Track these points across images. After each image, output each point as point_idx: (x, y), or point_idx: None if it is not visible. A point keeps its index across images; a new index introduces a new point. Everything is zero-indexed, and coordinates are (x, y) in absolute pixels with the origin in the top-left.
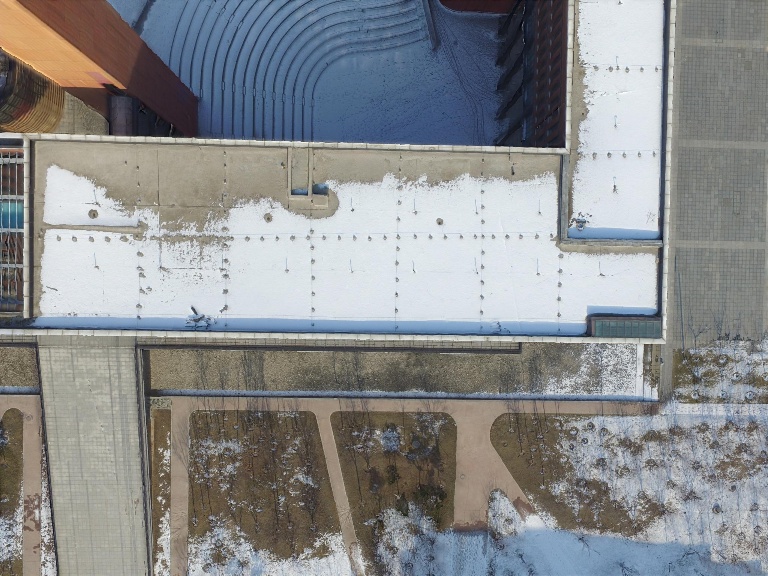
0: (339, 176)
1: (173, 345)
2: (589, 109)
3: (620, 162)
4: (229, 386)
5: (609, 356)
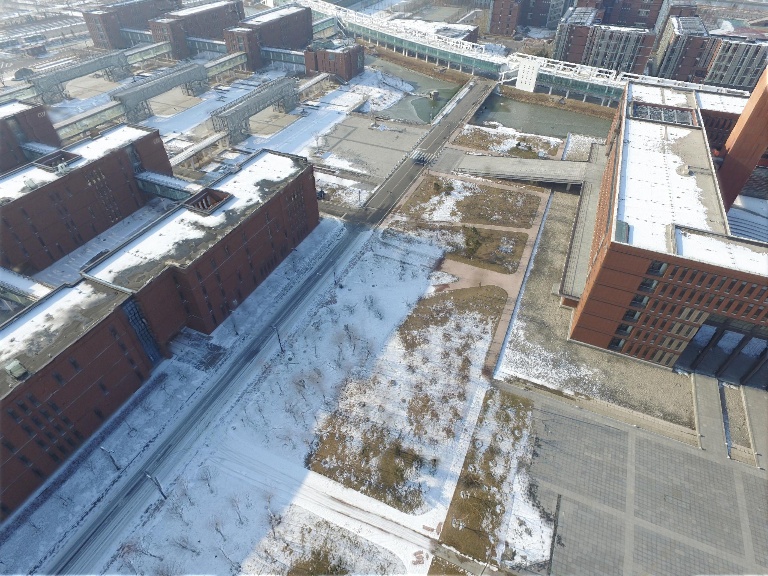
0: (699, 179)
1: (584, 189)
2: (759, 253)
3: (727, 255)
4: (551, 210)
5: (536, 361)
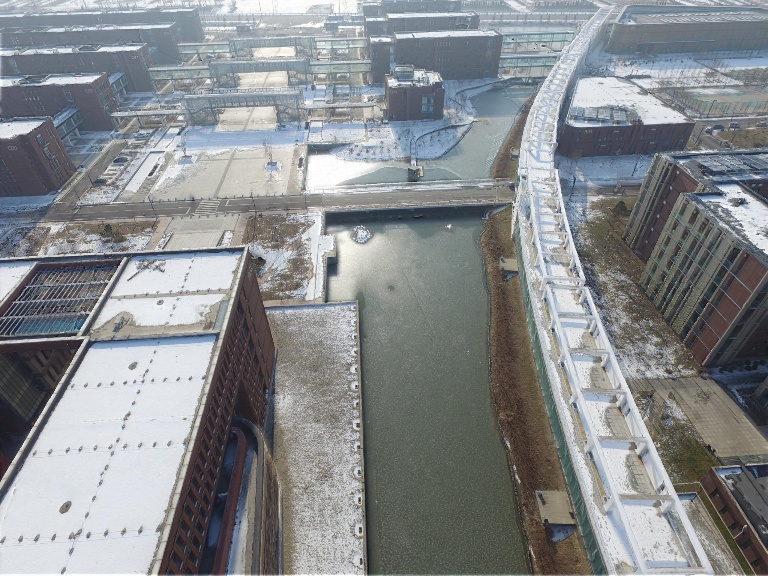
0: None
1: None
2: None
3: None
4: None
5: None
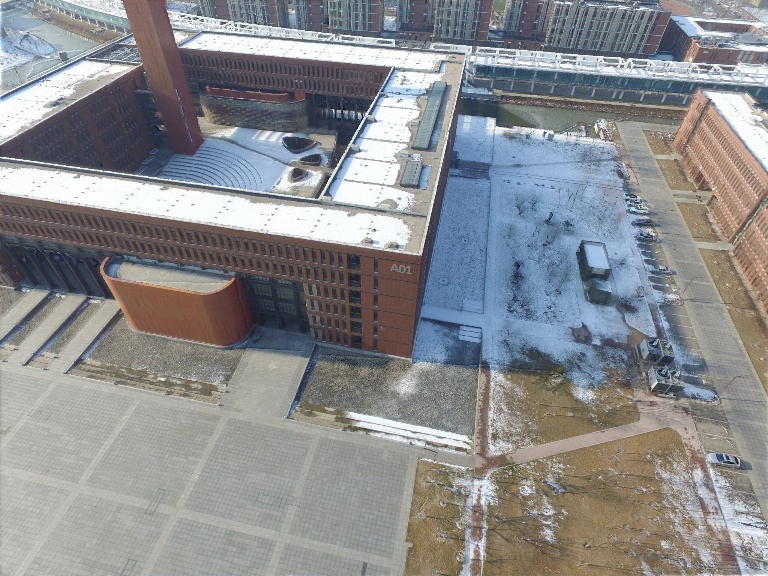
0: None
1: None
2: None
3: None
4: None
5: None
